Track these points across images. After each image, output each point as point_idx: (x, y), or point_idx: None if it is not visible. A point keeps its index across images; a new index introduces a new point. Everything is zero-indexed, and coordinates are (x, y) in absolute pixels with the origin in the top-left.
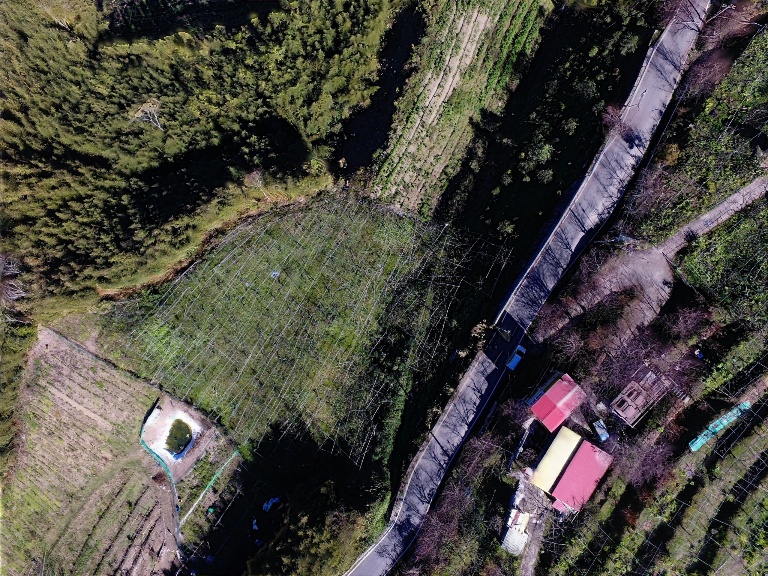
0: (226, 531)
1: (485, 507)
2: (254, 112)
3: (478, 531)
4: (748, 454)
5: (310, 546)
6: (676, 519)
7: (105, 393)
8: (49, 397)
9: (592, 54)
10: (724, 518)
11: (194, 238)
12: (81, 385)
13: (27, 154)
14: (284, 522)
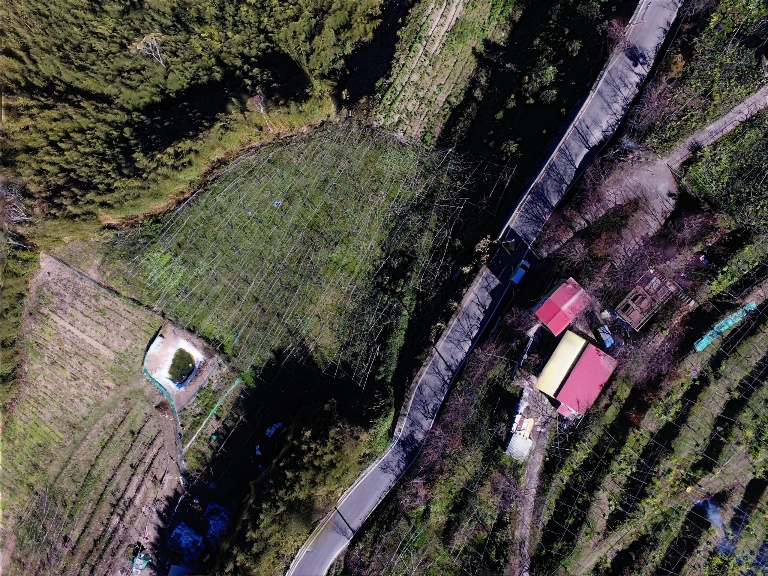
0: (229, 456)
1: (489, 417)
2: (256, 48)
3: (482, 441)
4: (754, 352)
5: (314, 459)
6: (681, 418)
7: (108, 321)
8: (51, 325)
9: None
10: (729, 414)
11: (196, 165)
12: (83, 313)
13: (29, 90)
14: (287, 441)
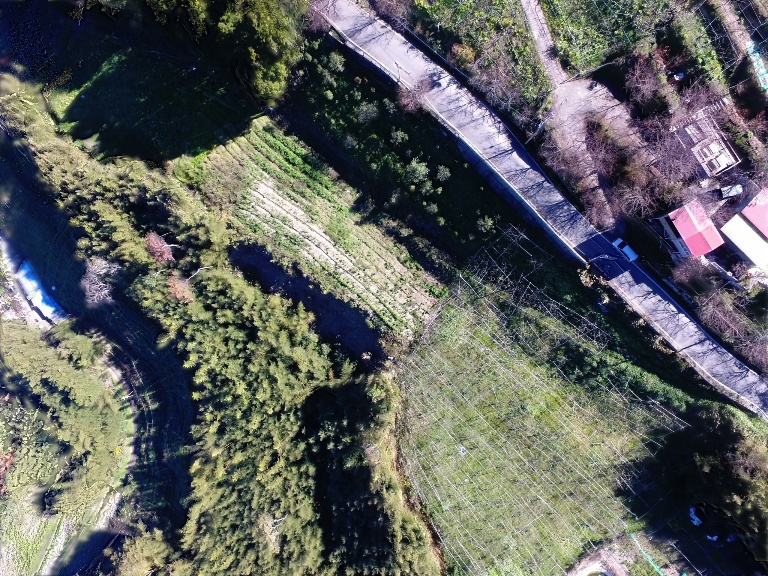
0: (712, 568)
1: None
2: (292, 425)
3: None
4: None
5: (766, 501)
6: None
7: None
8: None
9: (331, 97)
10: None
11: (411, 521)
12: None
13: None
14: (727, 515)
